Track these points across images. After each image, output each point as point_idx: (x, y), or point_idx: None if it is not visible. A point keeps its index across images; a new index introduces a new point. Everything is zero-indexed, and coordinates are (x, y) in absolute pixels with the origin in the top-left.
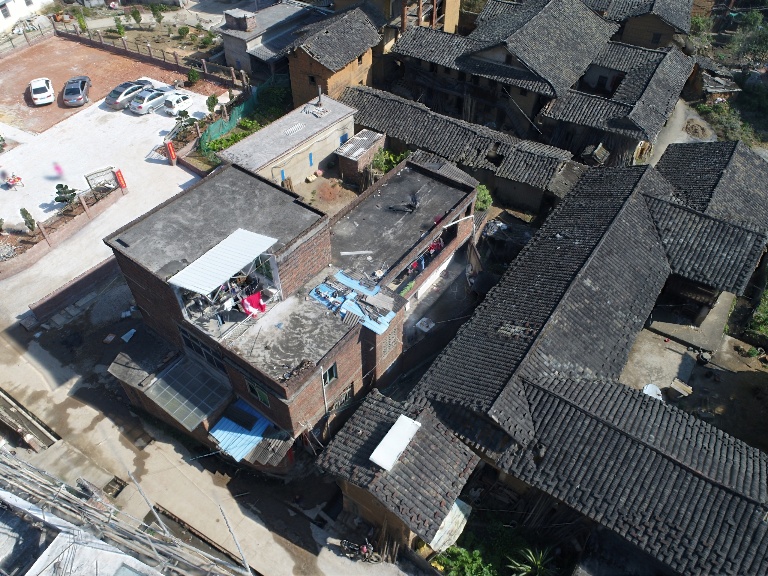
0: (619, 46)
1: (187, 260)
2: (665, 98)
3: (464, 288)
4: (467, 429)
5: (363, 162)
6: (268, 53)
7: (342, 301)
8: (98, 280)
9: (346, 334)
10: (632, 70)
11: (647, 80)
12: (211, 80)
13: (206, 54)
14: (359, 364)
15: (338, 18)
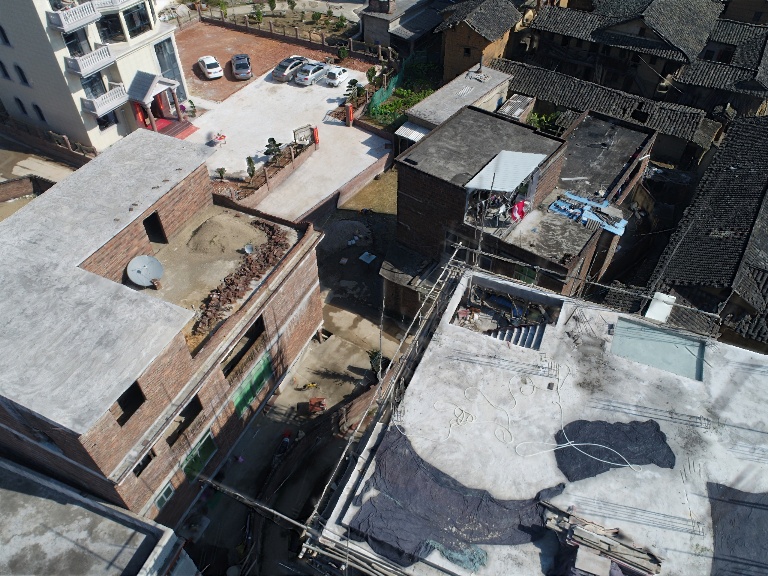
0: (727, 23)
1: (469, 173)
2: None
3: (633, 221)
4: (705, 305)
5: None
6: (407, 33)
7: (580, 212)
8: (319, 216)
9: (593, 235)
10: (741, 43)
11: (760, 50)
12: (356, 57)
13: (341, 36)
14: (588, 267)
15: None
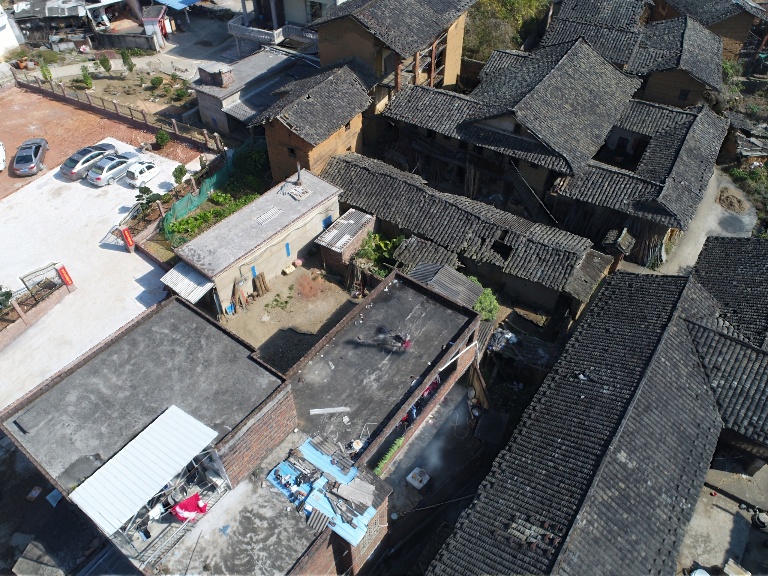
0: (642, 105)
1: (101, 456)
2: (698, 172)
3: (466, 420)
4: None
5: (349, 251)
6: (246, 111)
7: (307, 491)
8: None
9: (310, 546)
10: (658, 134)
11: (676, 149)
12: (183, 141)
13: (180, 108)
14: (331, 563)
15: (322, 78)
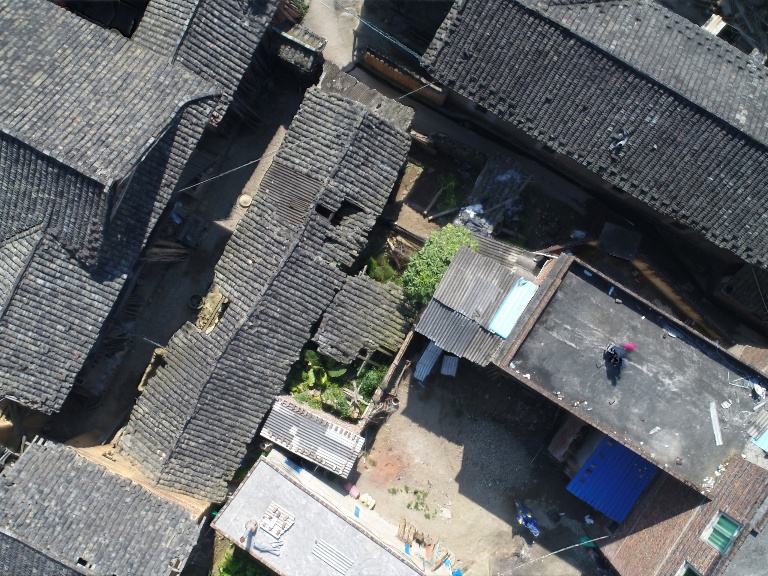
0: None
1: None
2: None
3: None
4: None
5: None
6: None
7: None
8: None
9: None
10: None
11: None
12: None
13: None
14: None
15: None
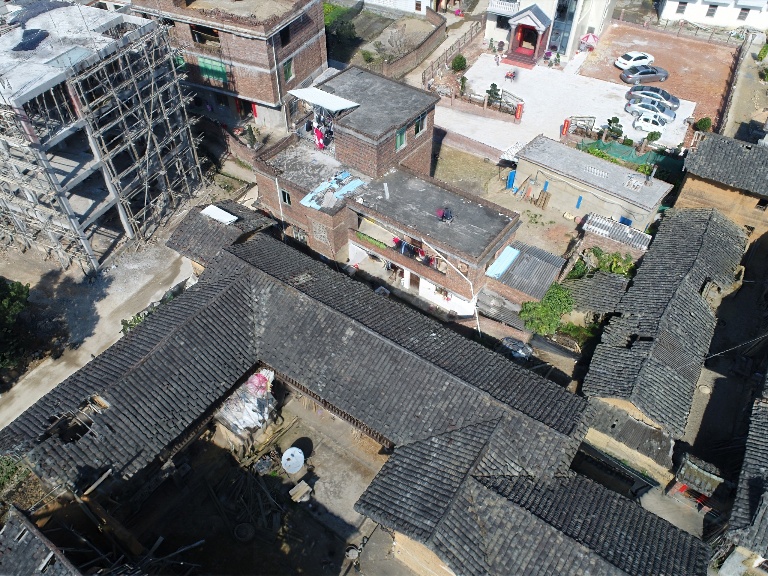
0: None
1: (334, 93)
2: None
3: None
4: None
5: (595, 241)
6: None
7: None
8: None
9: None
10: None
11: None
12: None
13: None
14: None
15: None
